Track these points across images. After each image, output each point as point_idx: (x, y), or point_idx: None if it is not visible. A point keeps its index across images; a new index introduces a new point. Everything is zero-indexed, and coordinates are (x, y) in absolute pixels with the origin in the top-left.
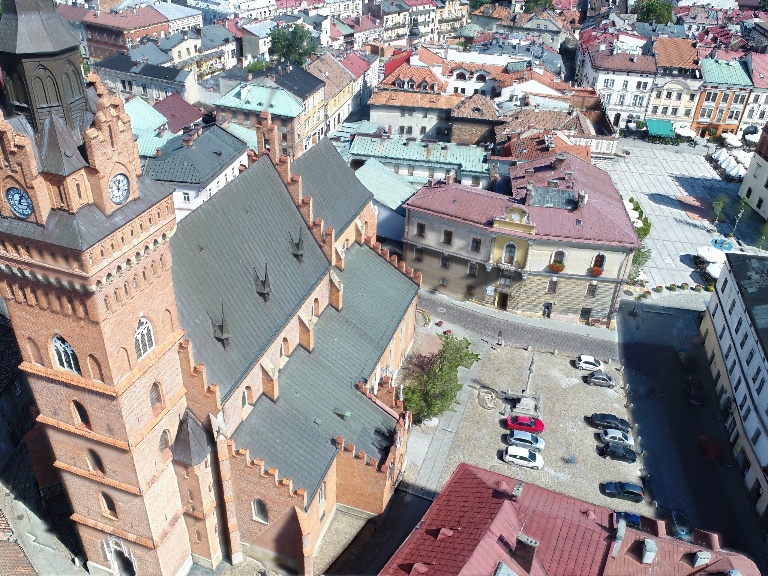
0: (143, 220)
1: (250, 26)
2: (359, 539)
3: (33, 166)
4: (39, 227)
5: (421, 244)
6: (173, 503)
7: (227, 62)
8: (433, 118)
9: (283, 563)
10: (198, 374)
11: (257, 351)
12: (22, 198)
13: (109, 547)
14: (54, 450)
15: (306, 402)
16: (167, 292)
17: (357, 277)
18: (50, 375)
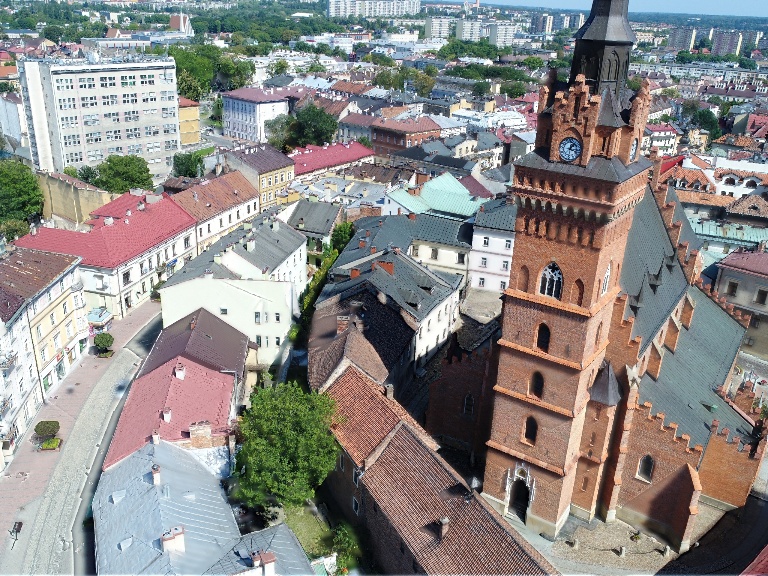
0: (636, 179)
1: (519, 134)
2: (721, 525)
3: (596, 119)
4: (581, 168)
5: (731, 302)
6: (577, 443)
7: (494, 163)
8: (704, 215)
9: (654, 528)
10: (627, 326)
11: (653, 329)
12: (574, 145)
13: (512, 476)
14: (498, 374)
15: (678, 389)
16: (622, 249)
17: (694, 308)
18: (531, 299)
